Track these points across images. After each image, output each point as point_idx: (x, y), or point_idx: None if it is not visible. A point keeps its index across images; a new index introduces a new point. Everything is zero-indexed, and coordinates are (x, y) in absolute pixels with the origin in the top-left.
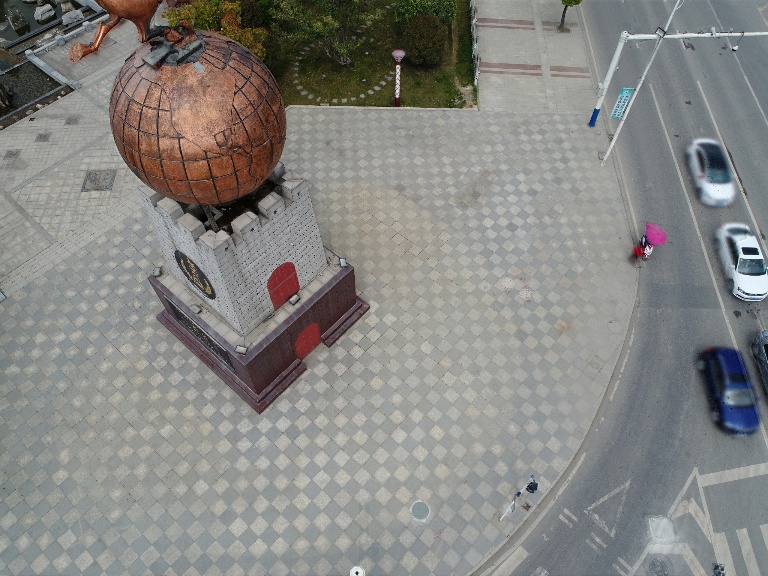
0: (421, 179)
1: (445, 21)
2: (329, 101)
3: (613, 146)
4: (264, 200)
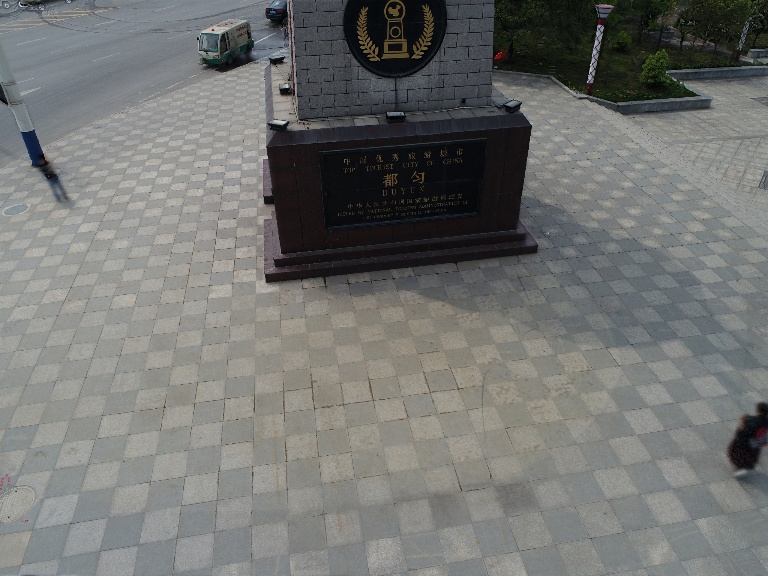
0: None
1: None
2: None
3: None
4: None
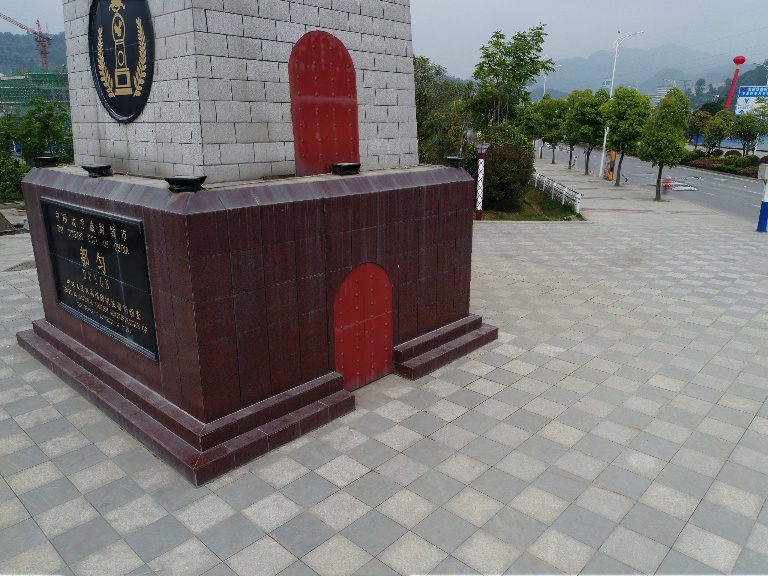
0: (537, 251)
1: None
2: None
3: None
4: None
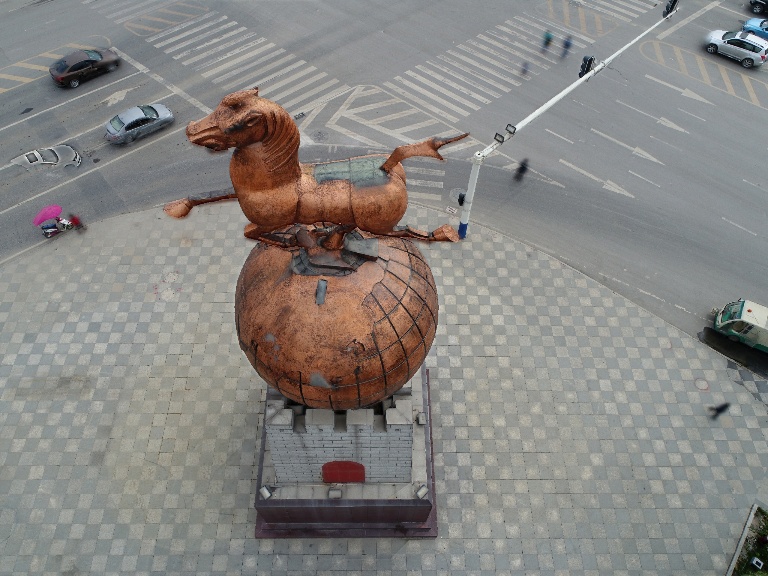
0: (69, 448)
1: None
2: None
3: None
4: None
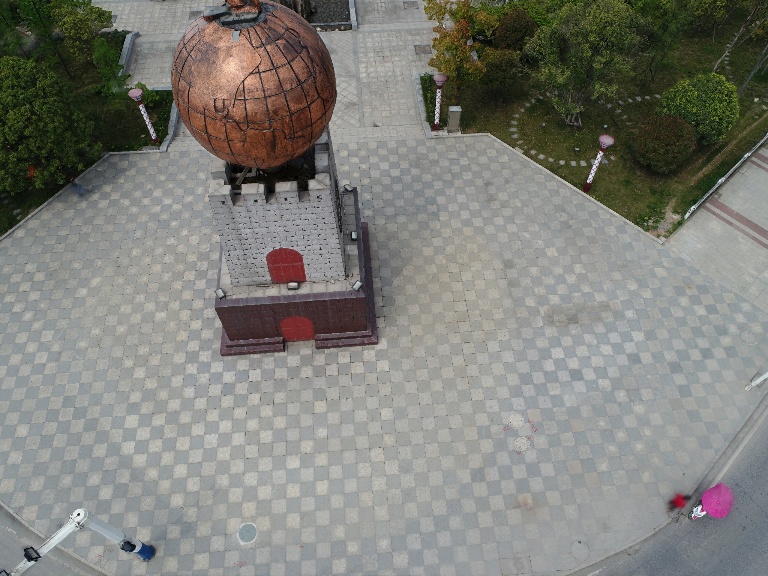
0: (536, 269)
1: (706, 137)
2: (527, 149)
3: None
4: (282, 183)
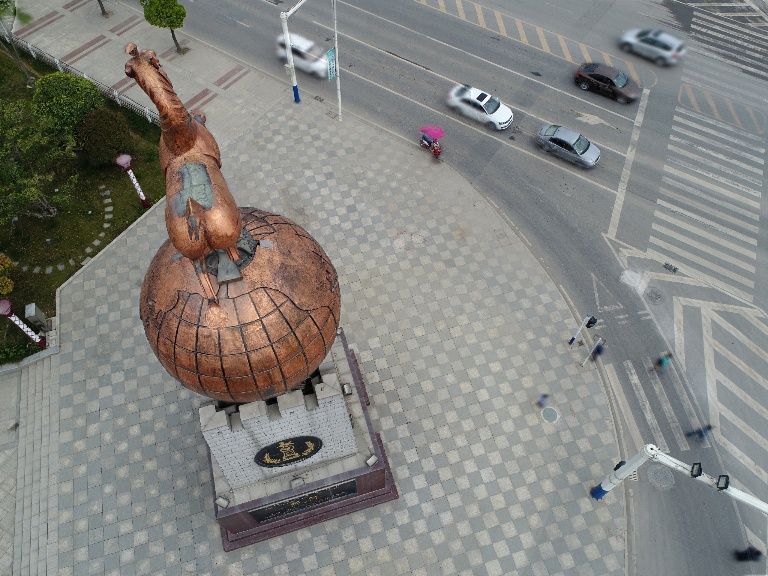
0: None
1: None
2: (85, 255)
3: (327, 103)
4: None
